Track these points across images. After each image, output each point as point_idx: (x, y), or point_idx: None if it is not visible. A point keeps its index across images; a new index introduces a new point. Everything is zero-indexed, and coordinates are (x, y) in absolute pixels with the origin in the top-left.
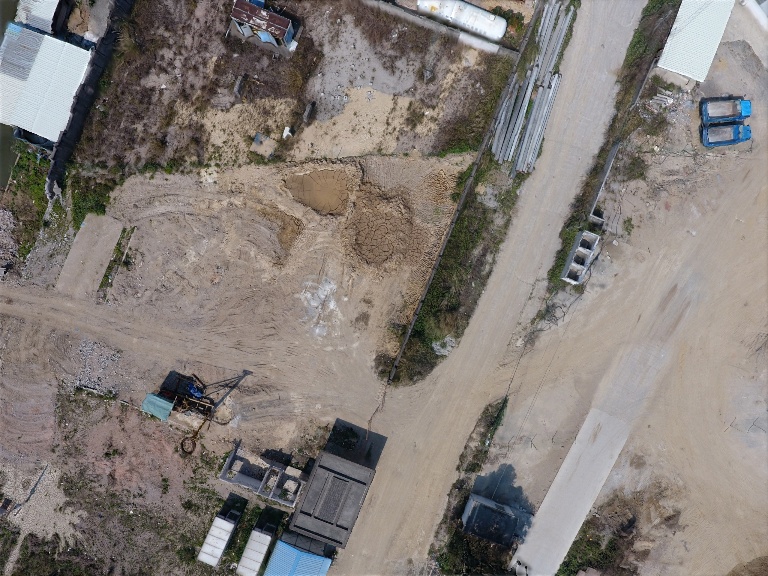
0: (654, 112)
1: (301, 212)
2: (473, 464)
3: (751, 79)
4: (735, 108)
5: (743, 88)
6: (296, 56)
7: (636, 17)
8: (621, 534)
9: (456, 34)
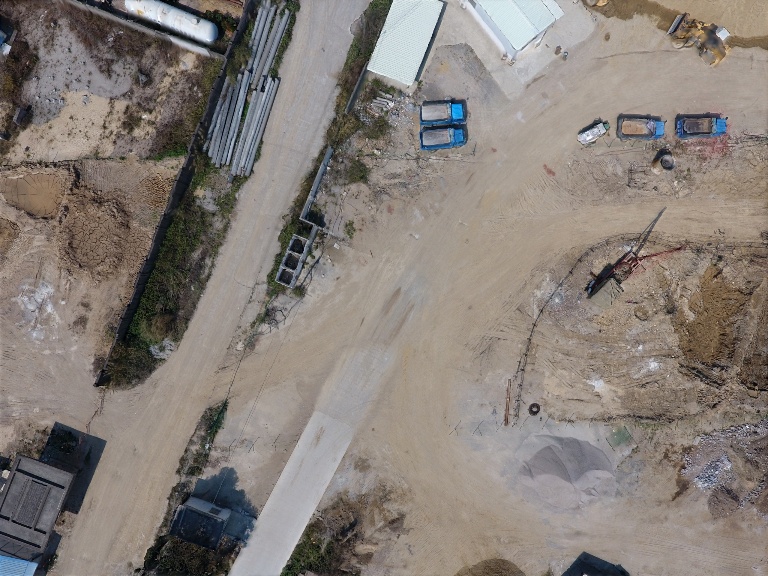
0: (375, 115)
1: (14, 216)
2: (193, 467)
3: (474, 82)
4: (447, 111)
5: (466, 91)
6: None
7: None
8: (338, 537)
9: (166, 38)
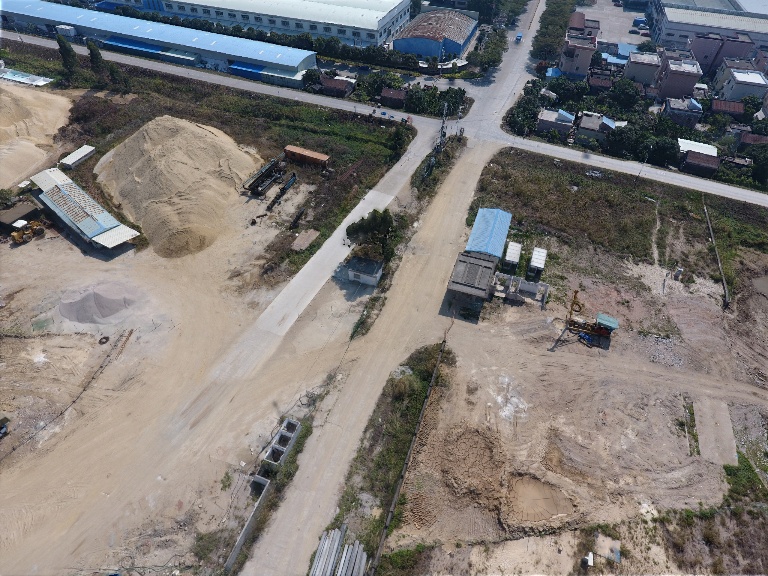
0: None
1: (549, 475)
2: (375, 301)
3: None
4: None
5: None
6: None
7: None
8: (275, 265)
9: None
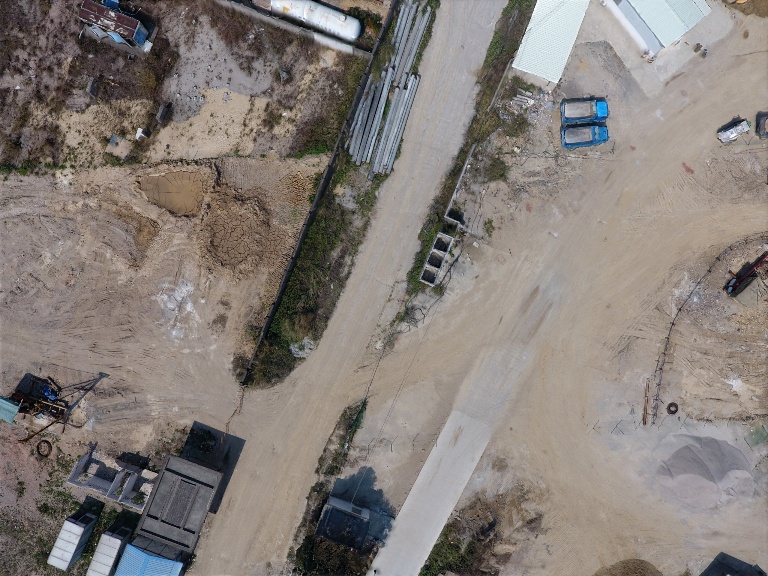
0: (515, 113)
1: (155, 214)
2: (332, 467)
3: (613, 80)
4: (591, 109)
5: (605, 89)
6: (151, 57)
7: (496, 18)
8: (479, 537)
9: (310, 35)
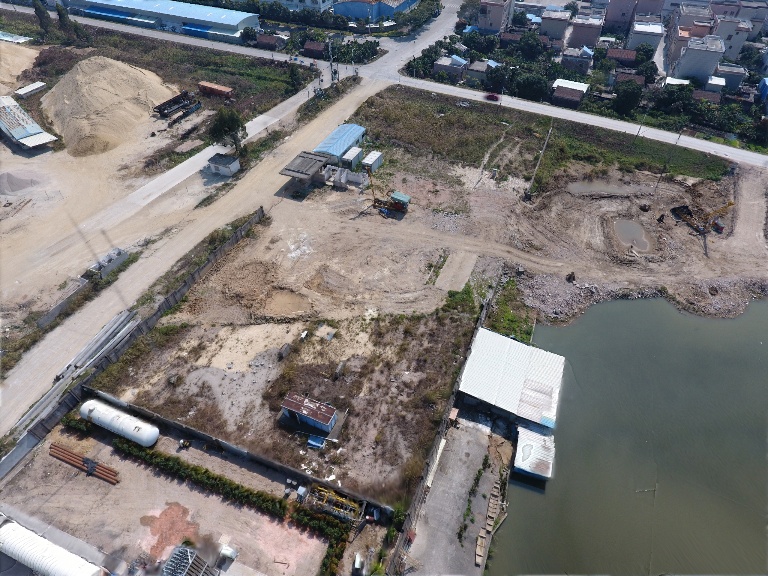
0: None
1: (303, 289)
2: (226, 186)
3: None
4: None
5: None
6: None
7: None
8: (155, 161)
9: None
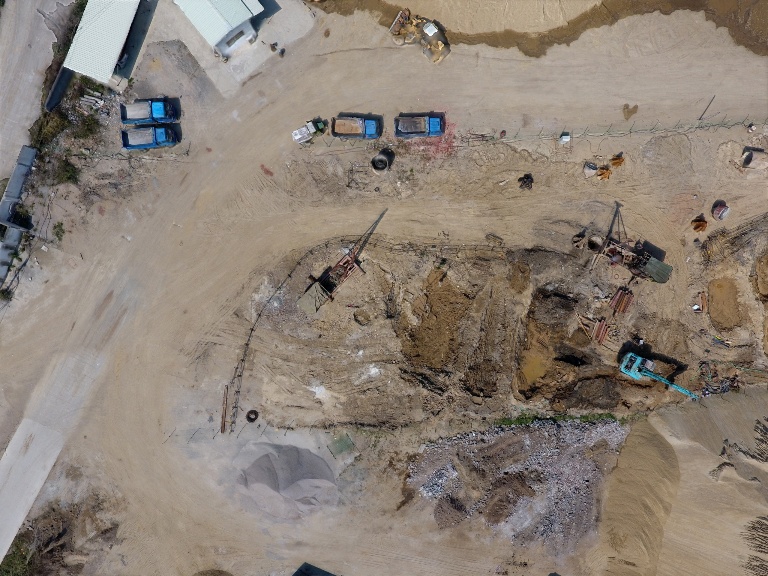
0: (84, 114)
1: None
2: None
3: (187, 80)
4: None
5: (179, 89)
6: None
7: None
8: (41, 548)
9: None
